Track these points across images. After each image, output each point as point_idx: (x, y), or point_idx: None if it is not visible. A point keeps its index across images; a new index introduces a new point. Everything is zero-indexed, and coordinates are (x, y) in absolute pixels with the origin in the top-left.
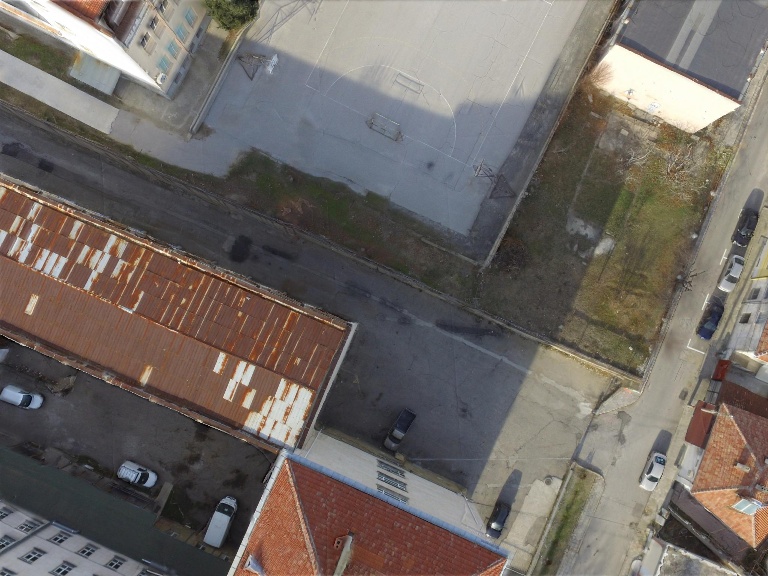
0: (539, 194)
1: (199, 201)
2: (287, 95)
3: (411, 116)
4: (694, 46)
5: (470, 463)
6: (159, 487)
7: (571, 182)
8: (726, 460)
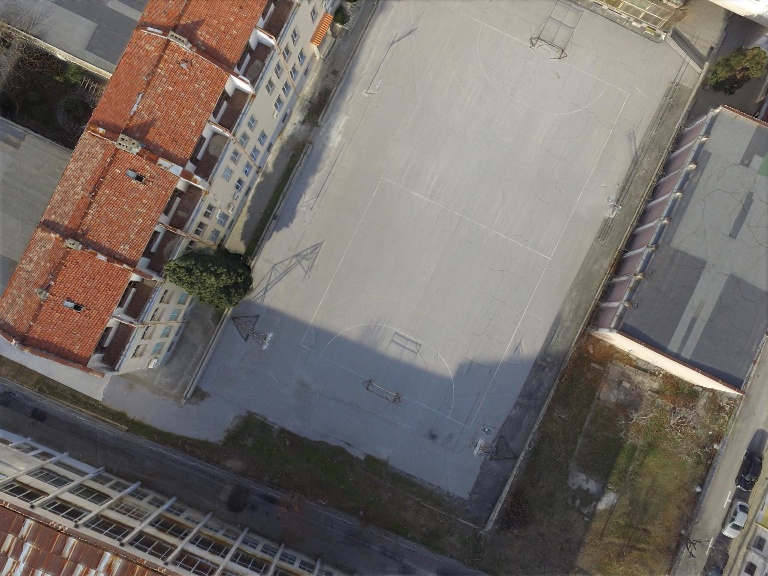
0: (539, 448)
1: None
2: (282, 356)
3: (408, 376)
4: (696, 333)
5: None
6: None
7: (572, 435)
8: None
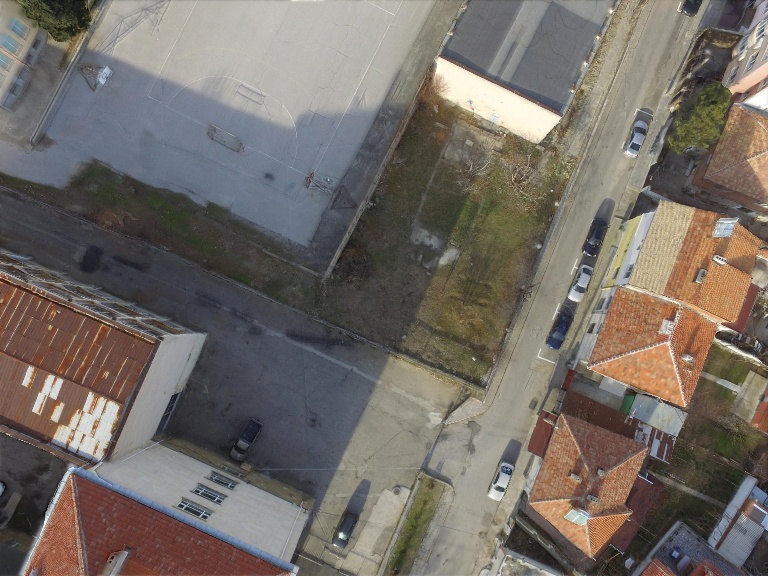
0: (384, 205)
1: (50, 212)
2: (129, 106)
3: (253, 127)
4: (516, 58)
5: (319, 473)
6: (7, 497)
7: (416, 193)
8: (561, 471)
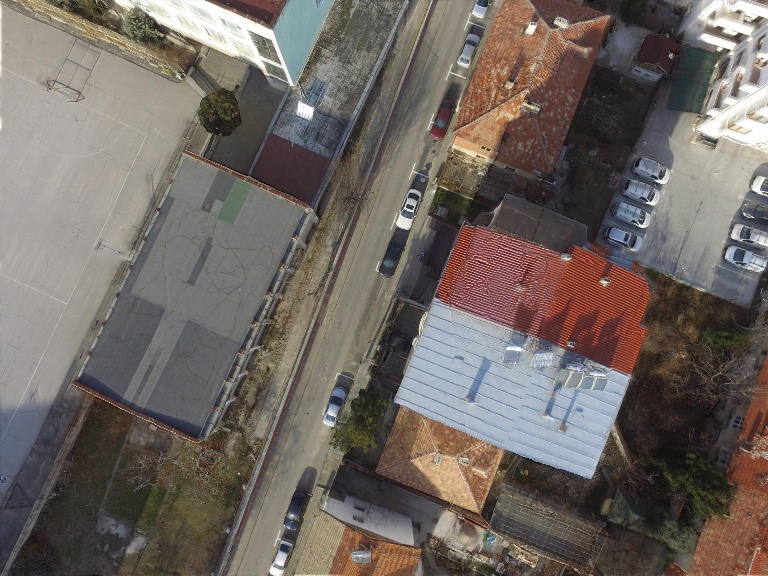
0: (68, 494)
1: None
2: None
3: None
4: (152, 382)
5: None
6: None
7: (101, 480)
8: None
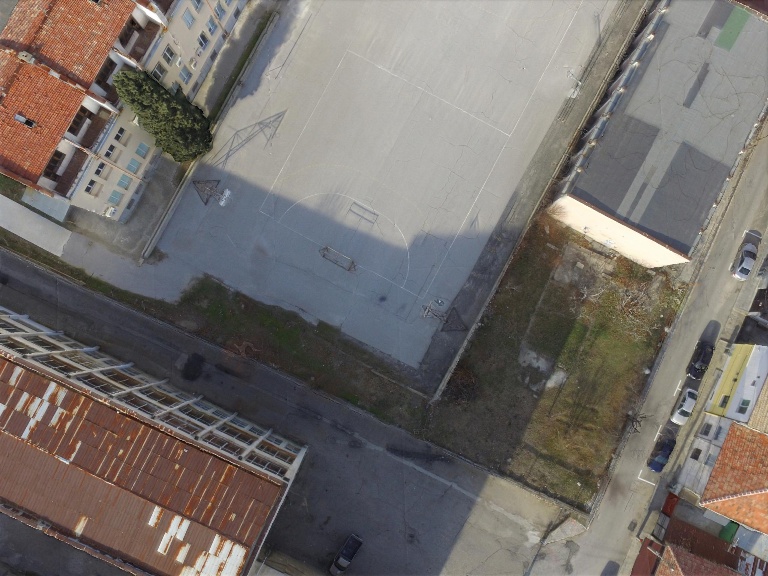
0: (492, 325)
1: None
2: (241, 221)
3: (365, 246)
4: (645, 199)
5: None
6: None
7: (525, 314)
8: None
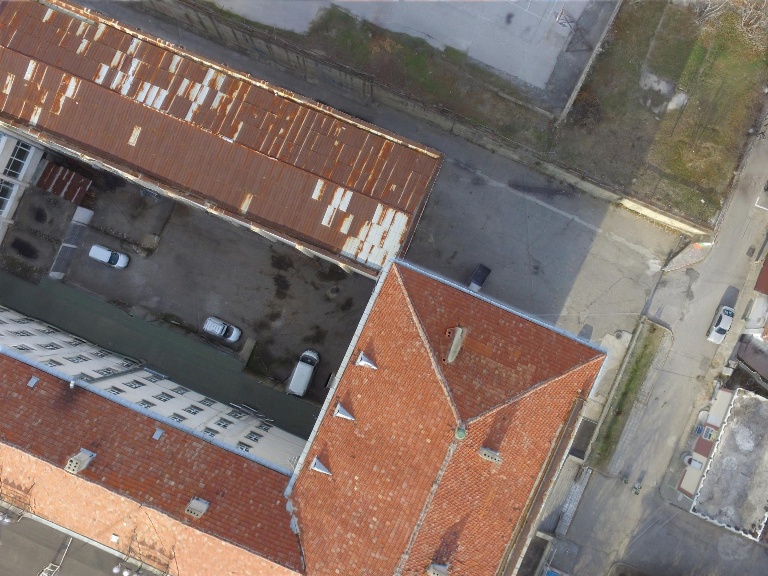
0: (613, 50)
1: (275, 65)
2: None
3: None
4: None
5: (542, 318)
6: (243, 342)
7: (645, 38)
8: None
